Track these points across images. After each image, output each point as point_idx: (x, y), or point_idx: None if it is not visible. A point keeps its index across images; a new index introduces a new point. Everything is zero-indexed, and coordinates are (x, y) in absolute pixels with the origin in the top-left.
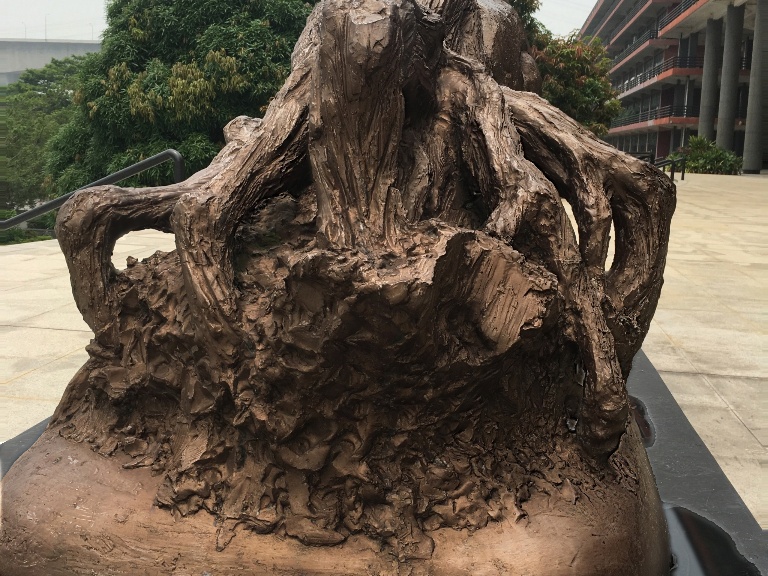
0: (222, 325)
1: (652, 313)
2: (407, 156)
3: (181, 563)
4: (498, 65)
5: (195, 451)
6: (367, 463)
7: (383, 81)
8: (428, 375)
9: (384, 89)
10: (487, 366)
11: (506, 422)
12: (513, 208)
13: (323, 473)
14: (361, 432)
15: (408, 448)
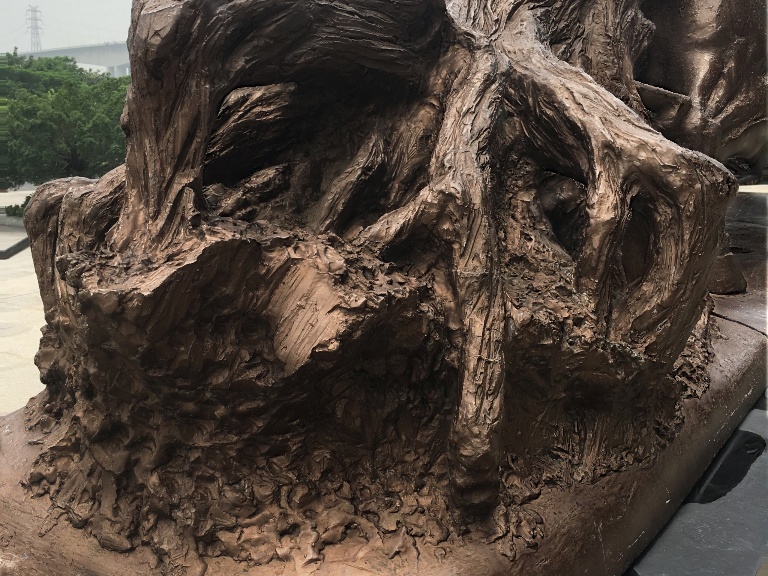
0: (70, 318)
1: (680, 340)
2: (357, 147)
3: (13, 541)
4: (725, 29)
5: (56, 437)
6: (158, 474)
7: (183, 73)
8: (208, 391)
9: (186, 81)
10: (282, 388)
11: (348, 452)
12: (408, 209)
13: (129, 477)
14: (156, 442)
15: (205, 465)
